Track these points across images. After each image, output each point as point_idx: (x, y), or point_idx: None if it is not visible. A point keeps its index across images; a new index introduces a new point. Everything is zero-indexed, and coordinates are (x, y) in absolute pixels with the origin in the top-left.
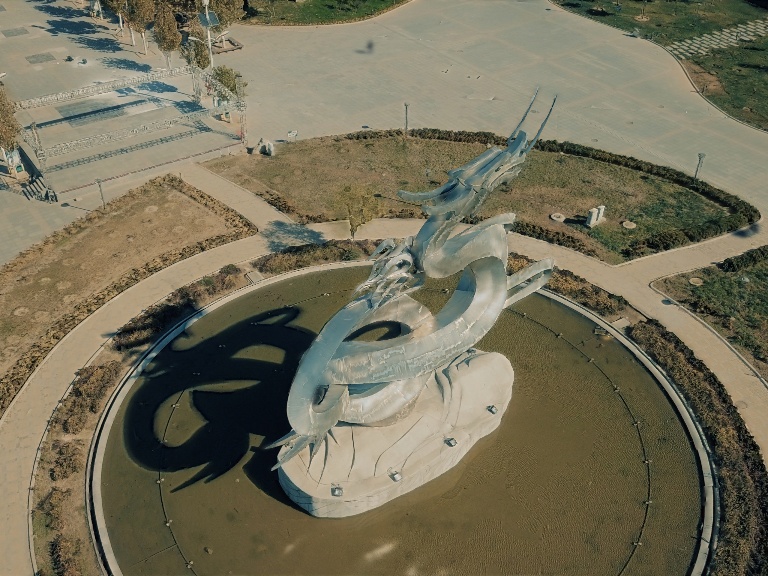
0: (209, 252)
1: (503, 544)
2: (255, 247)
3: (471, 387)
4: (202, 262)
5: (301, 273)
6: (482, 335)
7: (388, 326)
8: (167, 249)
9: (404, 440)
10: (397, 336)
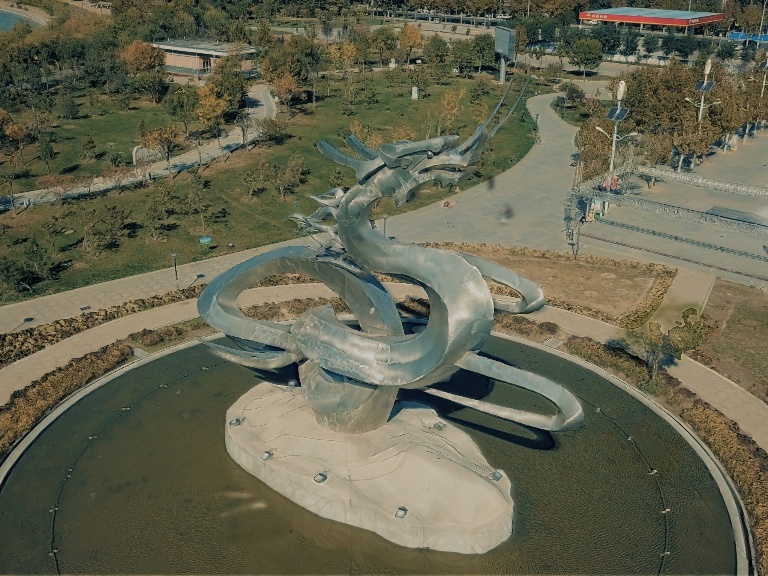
0: (569, 313)
1: (211, 571)
2: (603, 333)
3: (412, 473)
4: (549, 313)
5: (583, 364)
6: (394, 382)
7: (540, 437)
8: (554, 295)
9: (307, 441)
10: (527, 446)
